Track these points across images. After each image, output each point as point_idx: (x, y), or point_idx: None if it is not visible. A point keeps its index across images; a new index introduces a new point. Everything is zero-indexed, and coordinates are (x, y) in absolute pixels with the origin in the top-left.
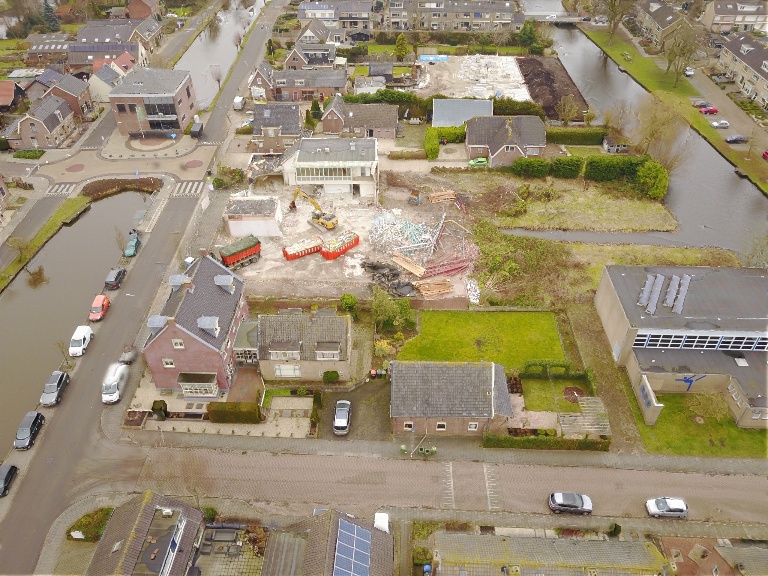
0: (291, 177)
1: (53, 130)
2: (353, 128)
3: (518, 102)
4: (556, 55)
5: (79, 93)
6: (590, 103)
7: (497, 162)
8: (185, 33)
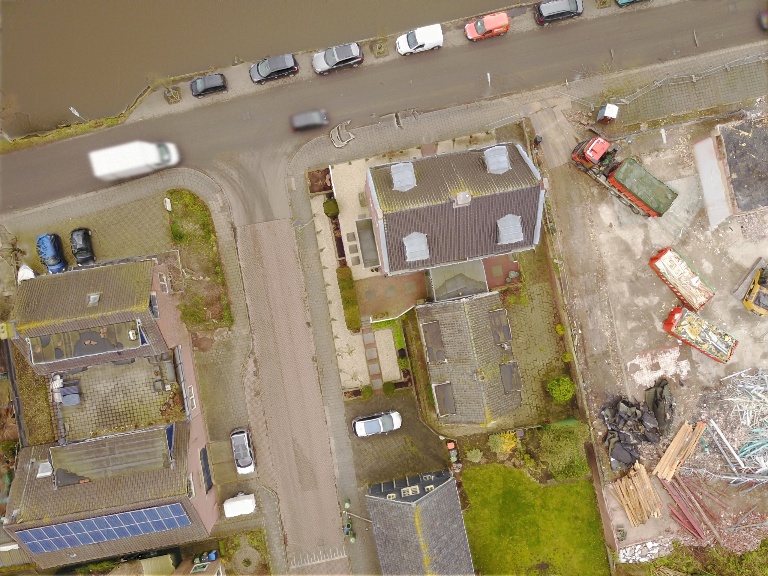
0: None
1: None
2: None
3: None
4: None
5: None
6: None
7: None
8: None
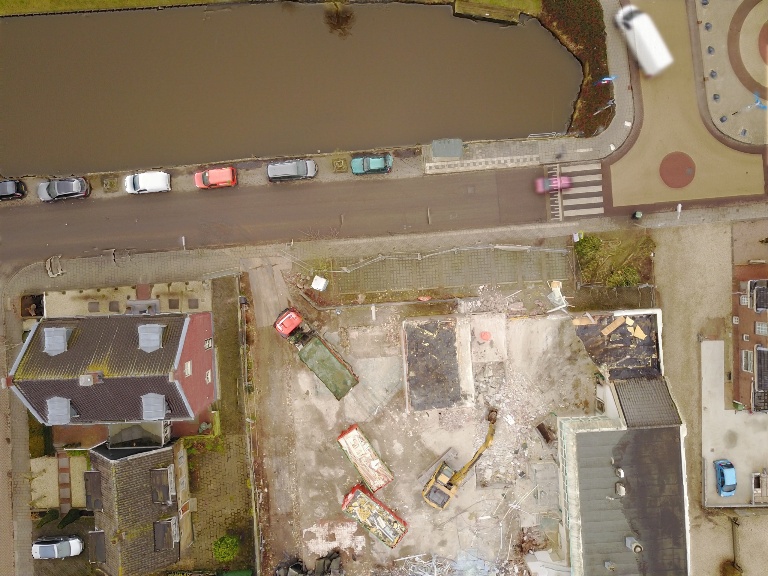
0: None
1: None
2: None
3: None
4: None
5: None
6: None
7: None
8: None
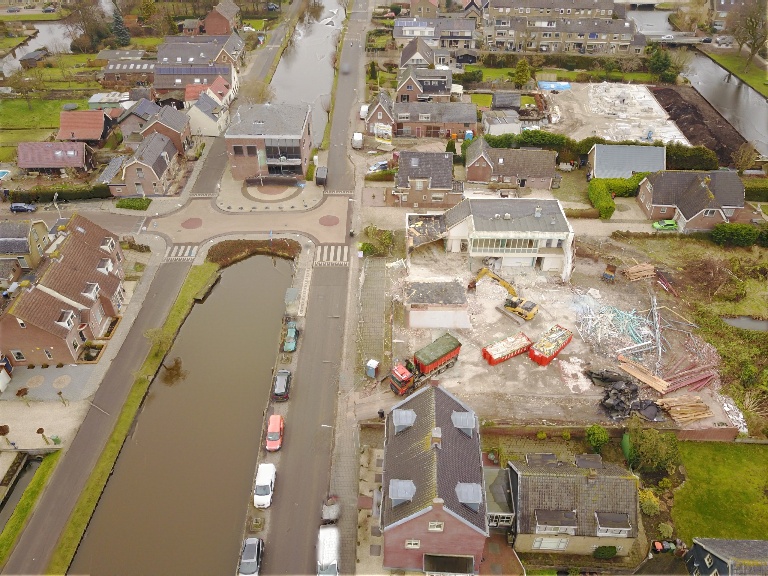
0: (456, 244)
1: (161, 176)
2: (503, 177)
3: (689, 148)
4: (690, 84)
5: (182, 128)
6: (757, 146)
7: (691, 227)
8: (269, 50)
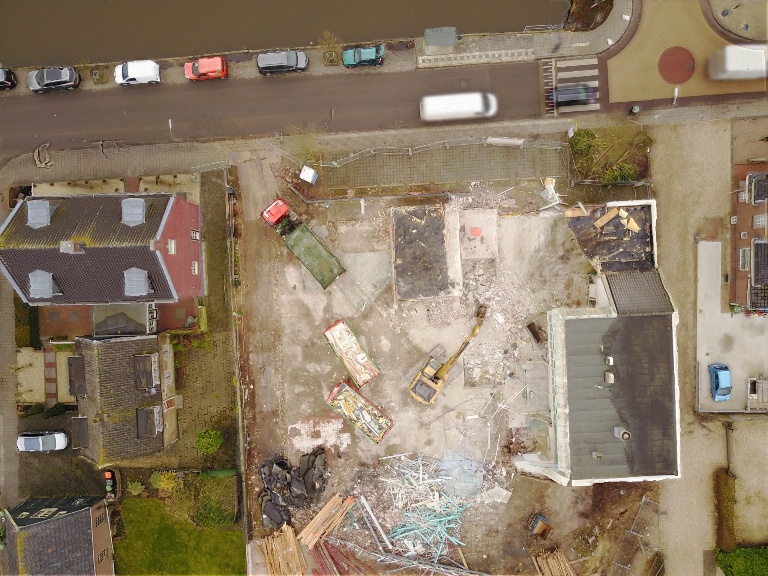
0: None
1: None
2: None
3: None
4: None
5: None
6: None
7: None
8: None
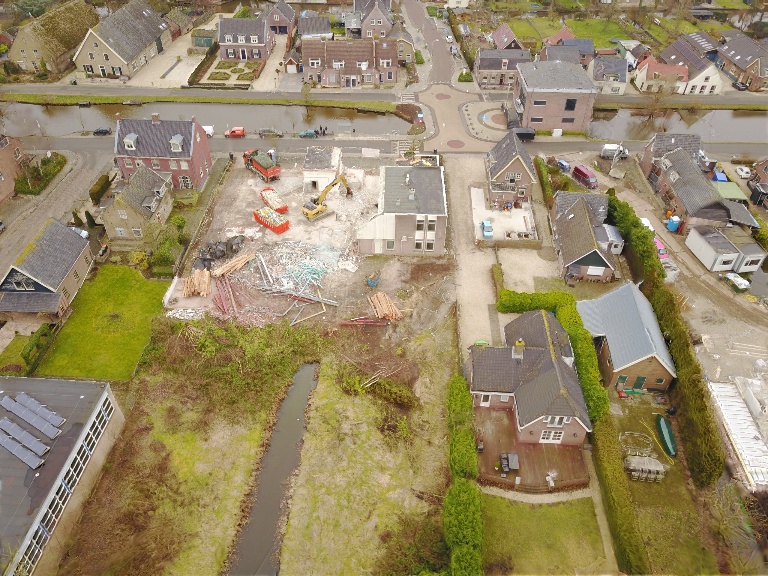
0: None
1: (485, 69)
2: None
3: (705, 411)
4: None
5: None
6: None
7: (470, 364)
8: None
